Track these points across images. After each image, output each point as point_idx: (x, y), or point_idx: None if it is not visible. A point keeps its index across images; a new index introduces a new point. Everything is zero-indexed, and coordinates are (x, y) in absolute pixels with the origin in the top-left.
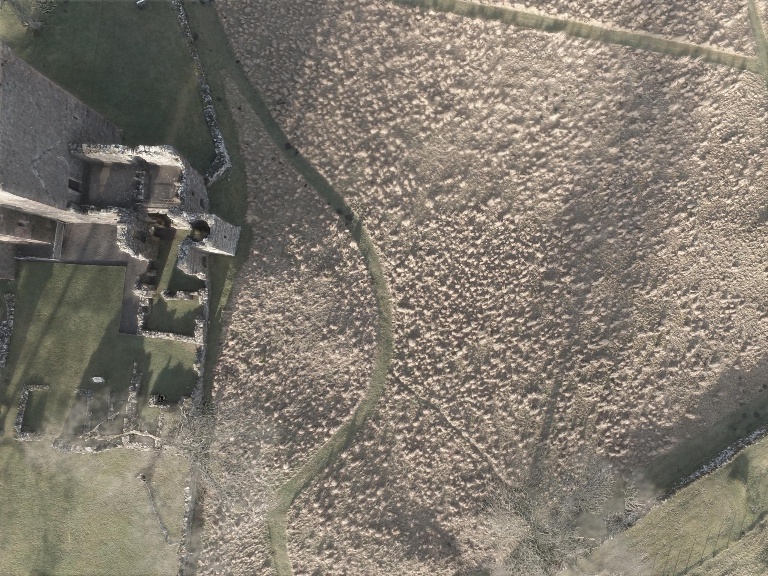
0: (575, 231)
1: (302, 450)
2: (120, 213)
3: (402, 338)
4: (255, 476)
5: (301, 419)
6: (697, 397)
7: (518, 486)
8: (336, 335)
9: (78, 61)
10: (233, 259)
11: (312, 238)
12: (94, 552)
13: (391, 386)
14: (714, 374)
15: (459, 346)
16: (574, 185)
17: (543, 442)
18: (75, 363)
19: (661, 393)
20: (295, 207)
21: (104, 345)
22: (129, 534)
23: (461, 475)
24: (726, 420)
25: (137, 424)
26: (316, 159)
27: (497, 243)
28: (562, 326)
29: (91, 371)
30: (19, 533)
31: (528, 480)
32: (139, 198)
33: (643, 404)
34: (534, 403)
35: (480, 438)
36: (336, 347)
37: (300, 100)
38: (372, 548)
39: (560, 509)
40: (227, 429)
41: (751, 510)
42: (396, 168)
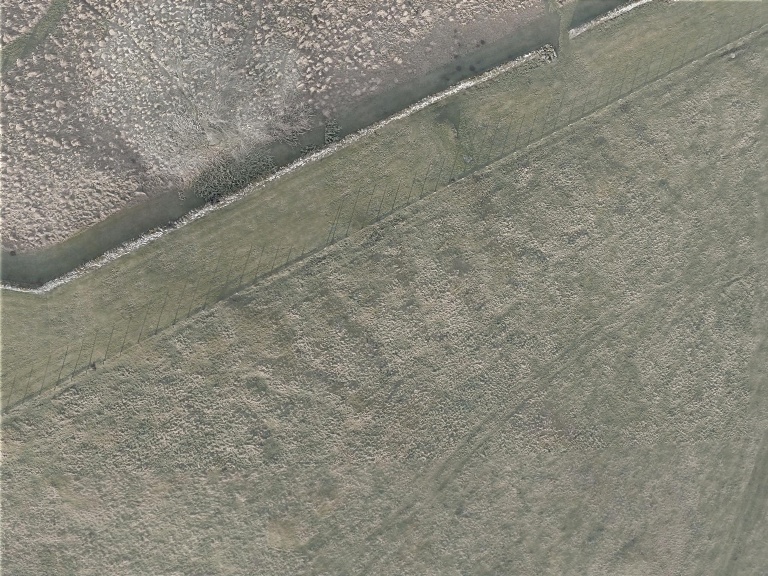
0: None
1: None
2: None
3: None
4: None
5: None
6: (408, 45)
7: (208, 110)
8: None
9: None
10: None
11: None
12: None
13: (75, 5)
14: (427, 24)
15: None
16: None
17: (238, 71)
18: None
19: (367, 34)
20: None
21: None
22: None
23: (149, 96)
24: (439, 71)
25: None
26: None
27: None
28: None
29: None
30: None
31: (219, 105)
32: None
33: (348, 45)
34: (230, 34)
35: (170, 62)
36: None
37: None
38: (49, 157)
39: (254, 137)
40: None
41: (463, 159)
42: None
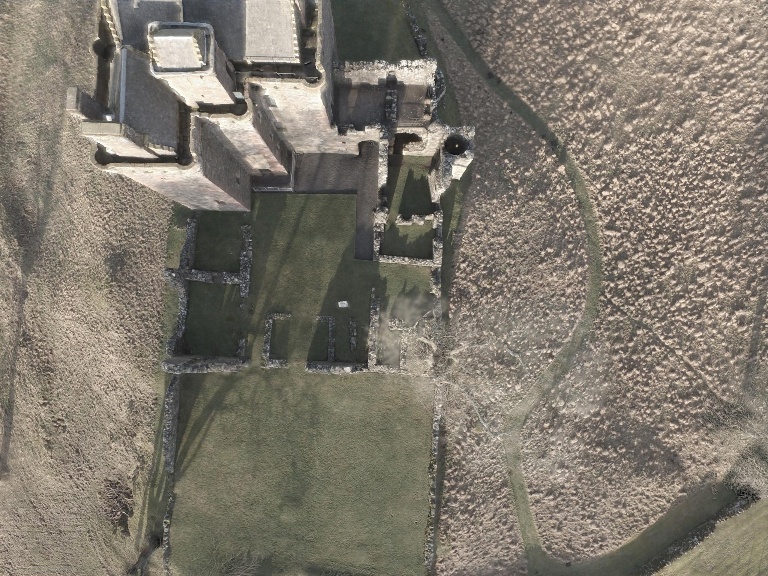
0: (767, 150)
1: (530, 371)
2: (383, 129)
3: (610, 260)
4: (491, 397)
5: (526, 341)
6: None
7: (733, 402)
8: (552, 258)
9: None
10: (459, 183)
11: (524, 163)
12: (343, 476)
13: (604, 308)
14: None
15: (666, 266)
16: (764, 104)
17: (753, 358)
18: (314, 291)
19: None
20: (505, 133)
21: (341, 272)
22: (377, 457)
23: (678, 393)
24: None
25: (379, 348)
26: (519, 86)
27: (694, 164)
28: (762, 244)
29: (330, 298)
30: (269, 461)
31: (742, 395)
32: (392, 117)
33: None
34: (741, 320)
35: (693, 356)
36: (553, 270)
37: (499, 30)
38: (600, 466)
39: None
40: (464, 350)
41: None
42: (594, 93)
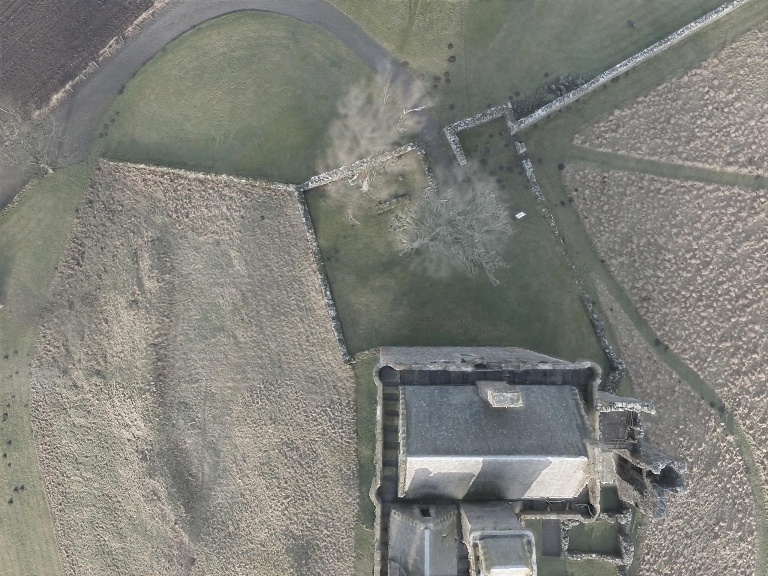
0: None
1: None
2: None
3: None
4: None
5: None
6: None
7: None
8: (725, 531)
9: (464, 279)
10: None
11: (697, 437)
12: None
13: None
14: None
15: None
16: None
17: None
18: None
19: None
20: (677, 406)
21: None
22: None
23: None
24: None
25: None
26: (687, 354)
27: None
28: None
29: None
30: None
31: None
32: None
33: None
34: None
35: None
36: (726, 543)
37: (664, 295)
38: None
39: None
40: None
41: None
42: (758, 355)
